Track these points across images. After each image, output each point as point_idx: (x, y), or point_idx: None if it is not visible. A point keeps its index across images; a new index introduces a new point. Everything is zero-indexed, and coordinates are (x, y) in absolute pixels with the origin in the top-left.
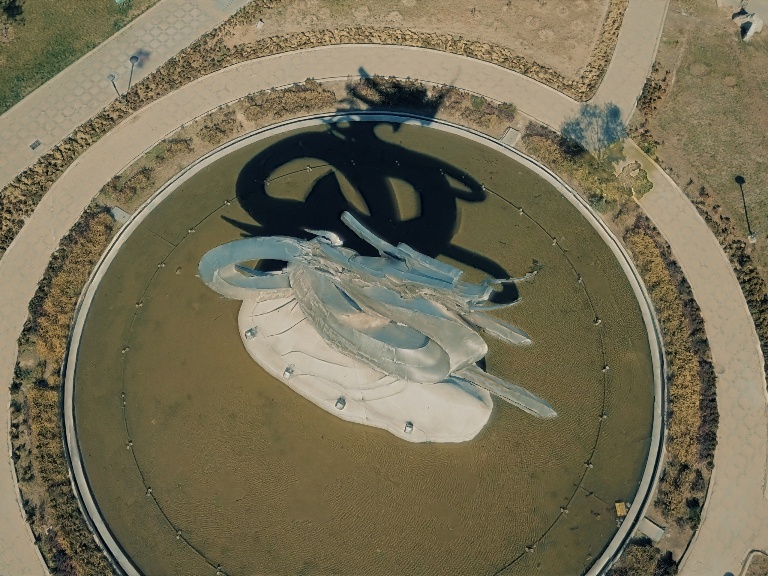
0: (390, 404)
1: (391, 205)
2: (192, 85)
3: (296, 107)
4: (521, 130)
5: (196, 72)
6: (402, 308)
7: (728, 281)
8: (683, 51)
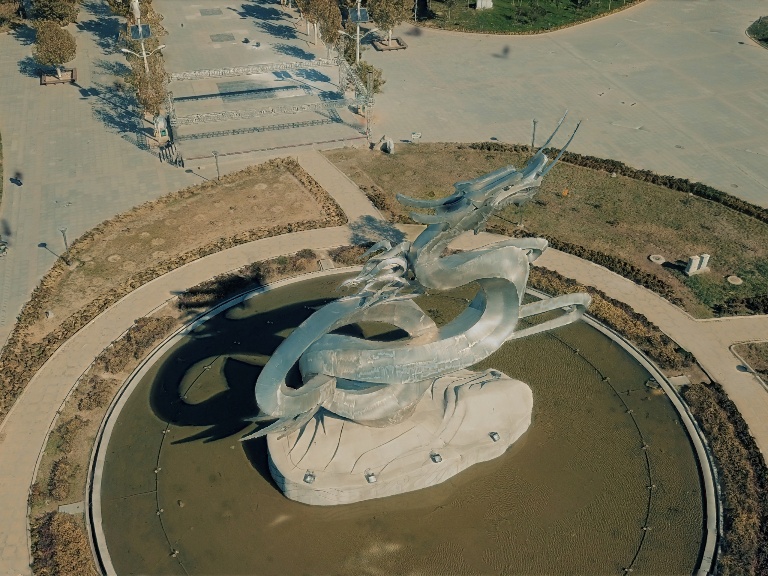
0: (466, 432)
1: None
2: (33, 384)
3: (149, 340)
4: (327, 258)
5: (27, 373)
6: (469, 261)
7: None
8: (366, 175)
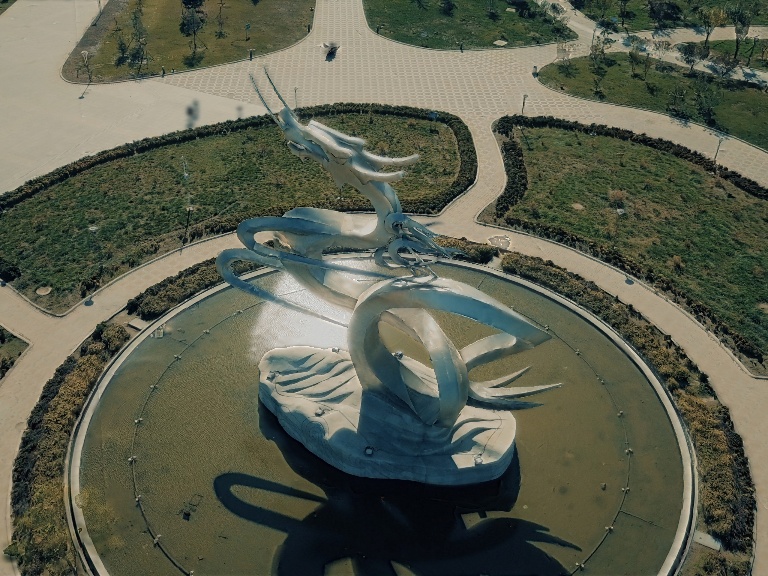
0: None
1: None
2: None
3: None
4: None
5: None
6: None
7: None
8: None
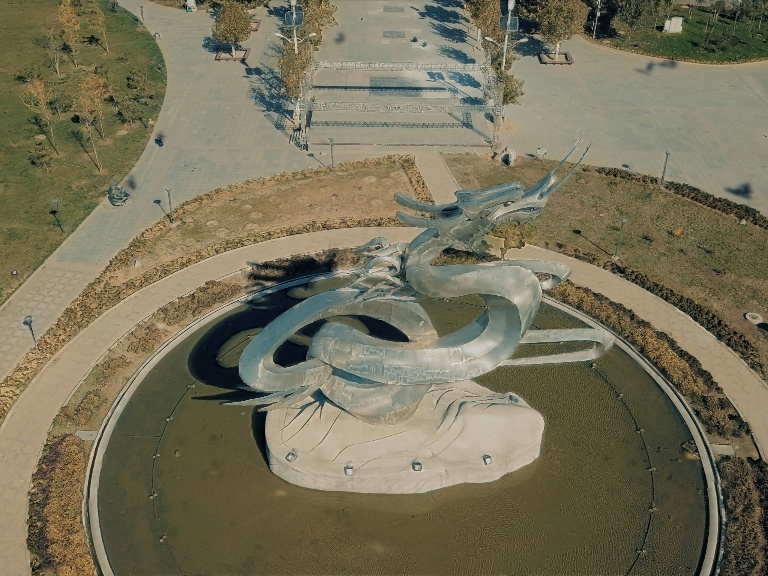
0: (459, 448)
1: None
2: (99, 320)
3: (210, 301)
4: None
5: (98, 310)
6: (467, 273)
7: (623, 284)
8: (477, 183)
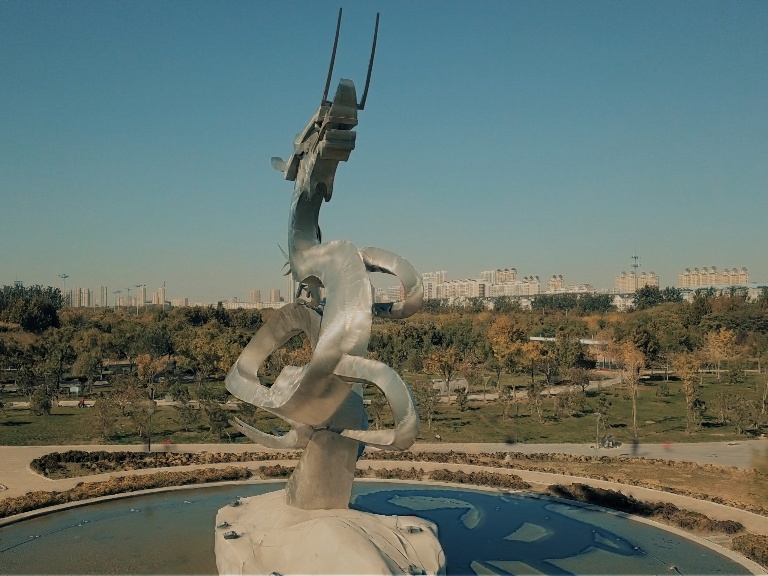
0: (282, 555)
1: (505, 532)
2: (409, 463)
3: (482, 480)
4: None
5: None
6: None
7: None
8: None
